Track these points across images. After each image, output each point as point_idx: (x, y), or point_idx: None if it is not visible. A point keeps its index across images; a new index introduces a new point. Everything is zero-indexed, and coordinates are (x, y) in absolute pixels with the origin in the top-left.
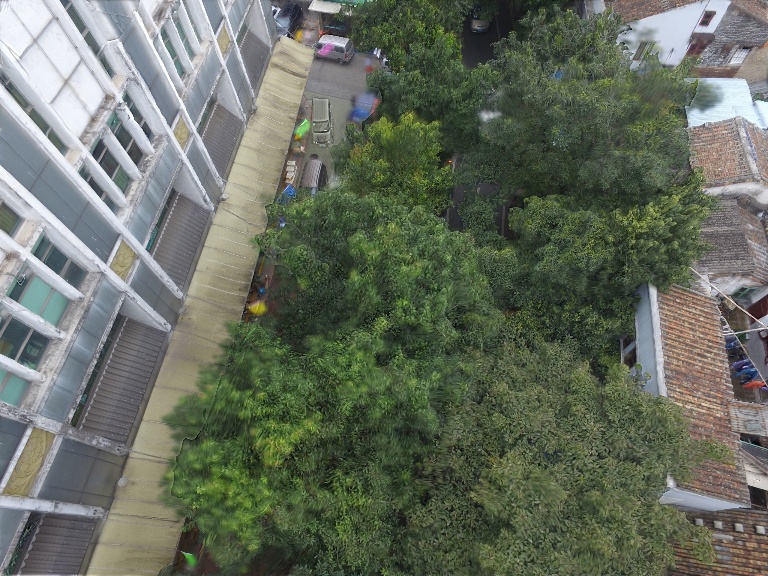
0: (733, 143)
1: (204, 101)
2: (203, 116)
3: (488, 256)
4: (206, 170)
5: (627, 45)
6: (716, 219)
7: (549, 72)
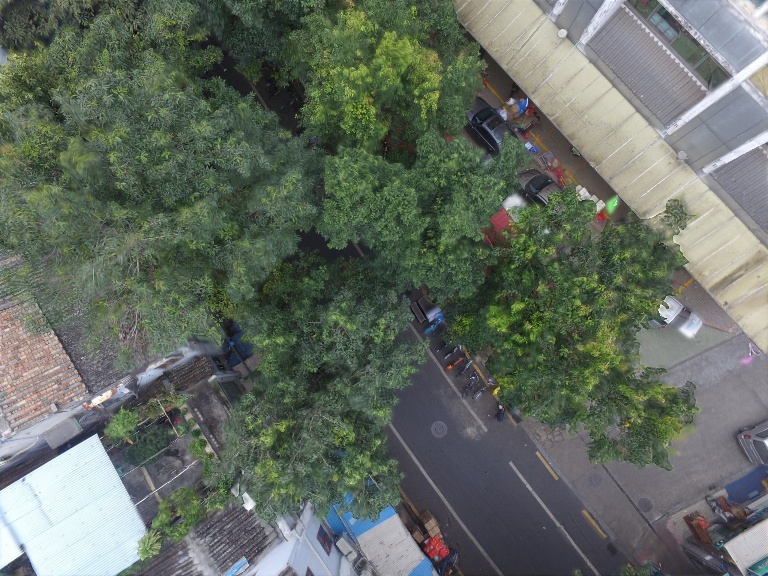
0: (2, 382)
1: (679, 8)
2: (692, 58)
3: (175, 7)
4: (596, 5)
5: (270, 569)
6: (1, 280)
7: (256, 239)
